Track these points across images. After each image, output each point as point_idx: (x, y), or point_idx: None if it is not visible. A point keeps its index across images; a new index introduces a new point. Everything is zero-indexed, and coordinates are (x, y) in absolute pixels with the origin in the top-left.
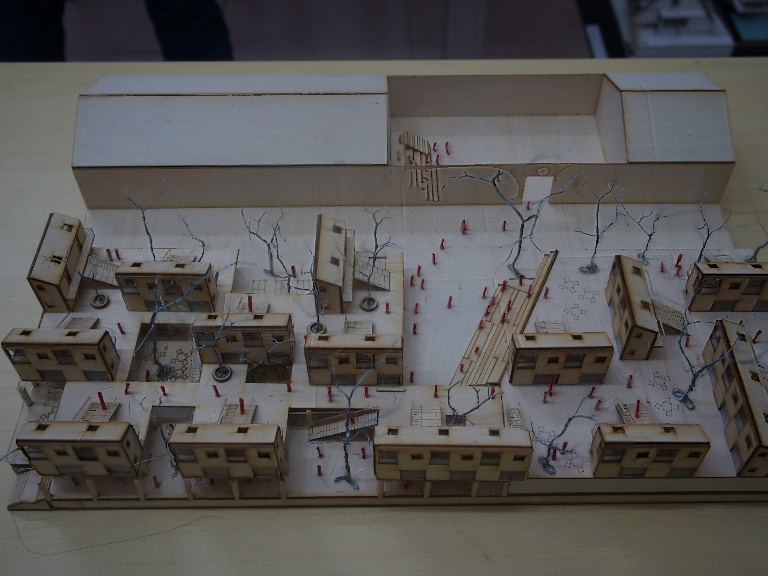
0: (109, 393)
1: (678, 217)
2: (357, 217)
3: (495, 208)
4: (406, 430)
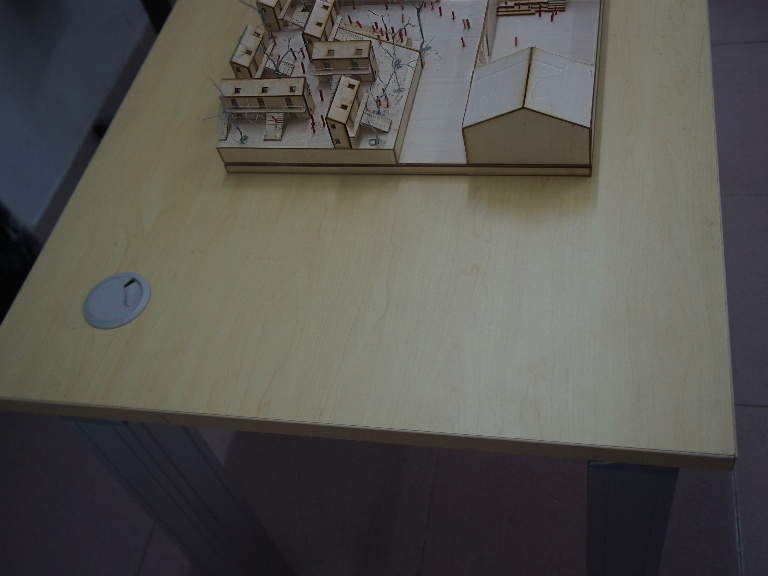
0: None
1: (456, 136)
2: None
3: None
4: None
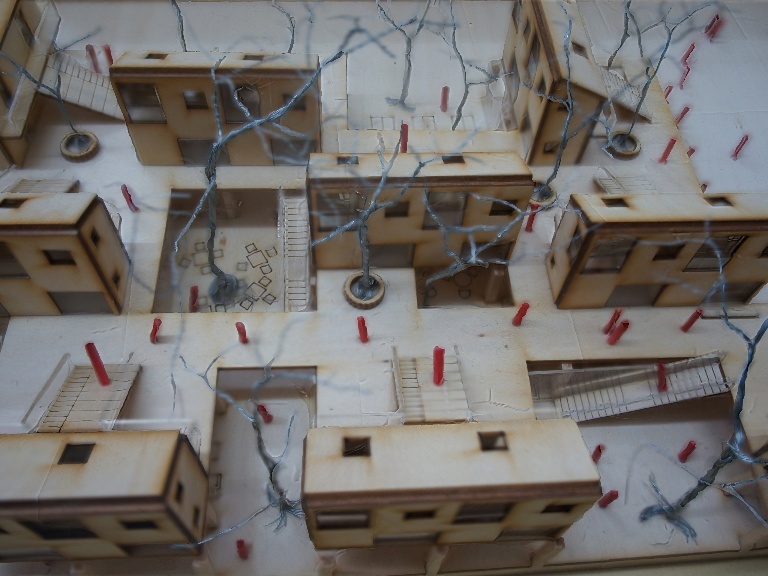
0: (113, 341)
1: None
2: None
3: (744, 5)
4: None
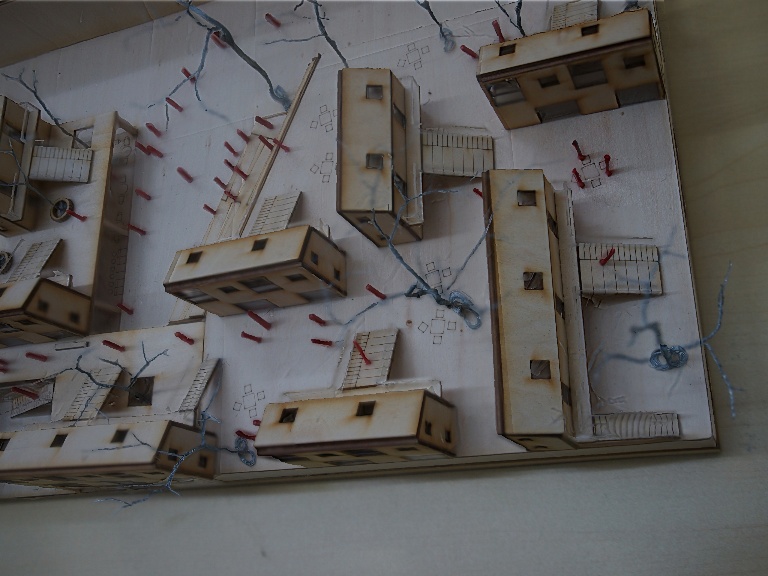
0: None
1: None
2: (97, 55)
3: None
4: (17, 440)
